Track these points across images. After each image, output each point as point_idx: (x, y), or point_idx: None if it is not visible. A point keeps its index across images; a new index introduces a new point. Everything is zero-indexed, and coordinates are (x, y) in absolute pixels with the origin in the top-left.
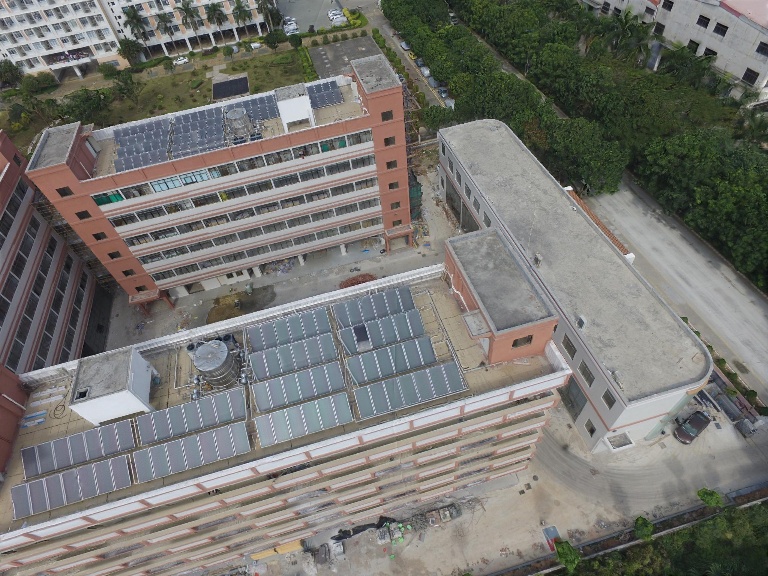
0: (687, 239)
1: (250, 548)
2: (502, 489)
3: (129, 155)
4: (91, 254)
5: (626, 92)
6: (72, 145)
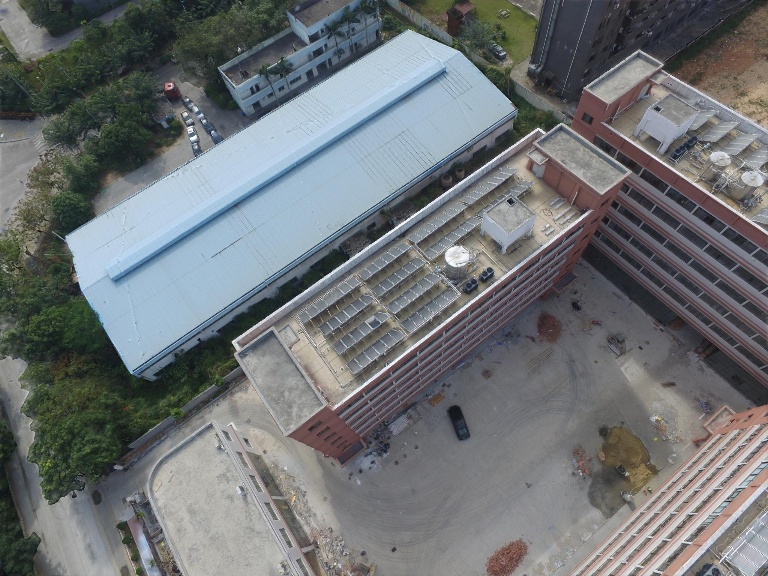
0: None
1: None
2: None
3: None
4: None
5: None
6: None
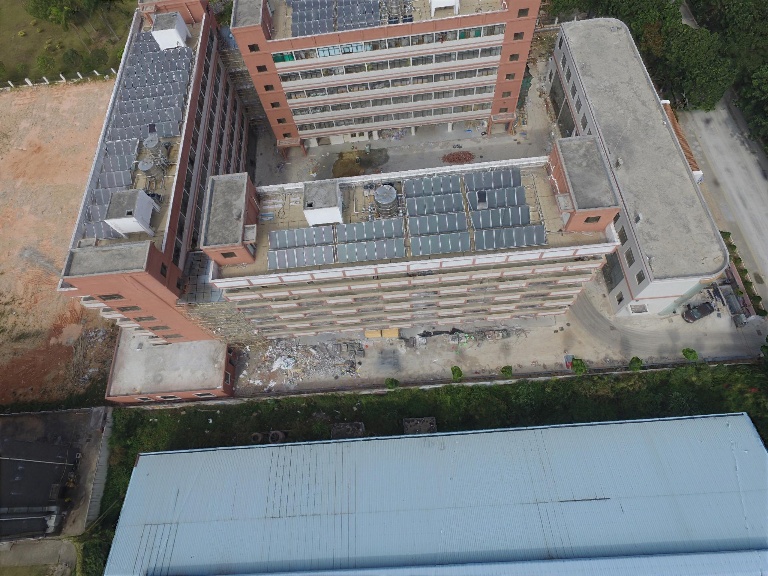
0: (762, 165)
1: (371, 325)
2: (542, 327)
3: (301, 20)
4: (250, 100)
5: (760, 4)
6: (262, 7)
